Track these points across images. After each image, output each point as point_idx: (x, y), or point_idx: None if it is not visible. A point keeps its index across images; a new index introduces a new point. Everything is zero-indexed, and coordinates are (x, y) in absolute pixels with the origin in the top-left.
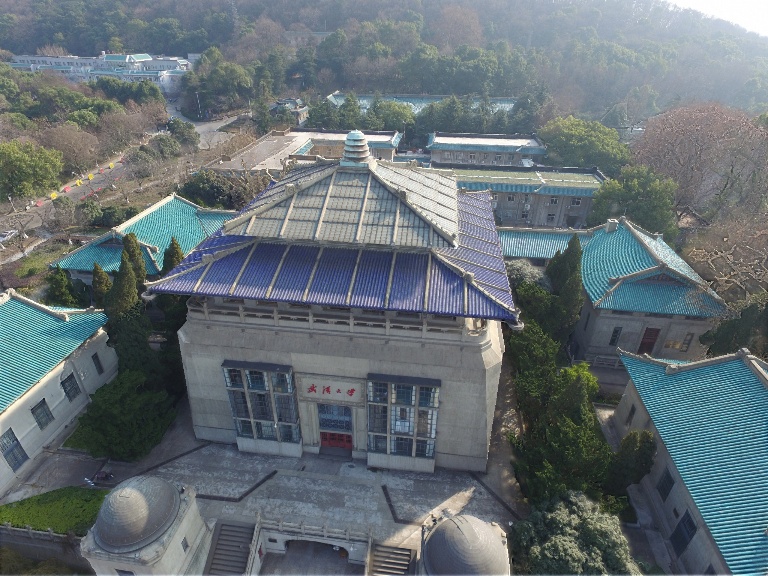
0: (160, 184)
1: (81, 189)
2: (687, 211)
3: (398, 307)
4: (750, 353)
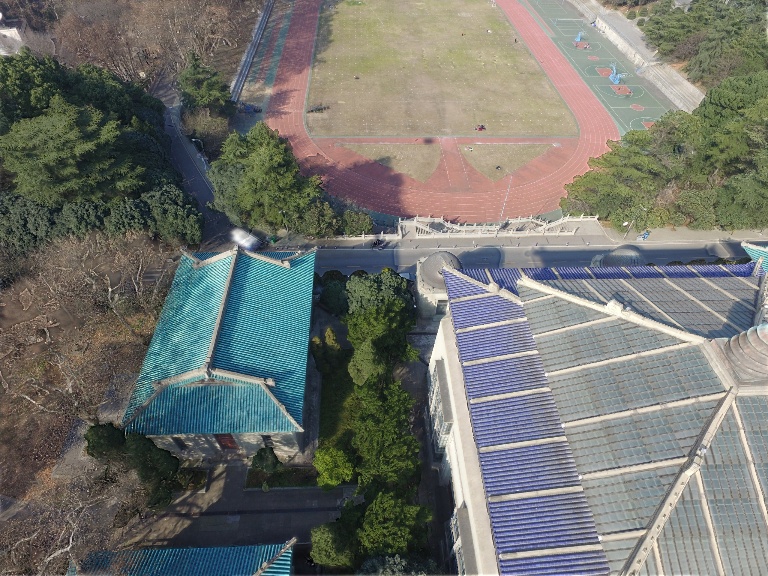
0: None
1: None
2: None
3: (542, 269)
4: None
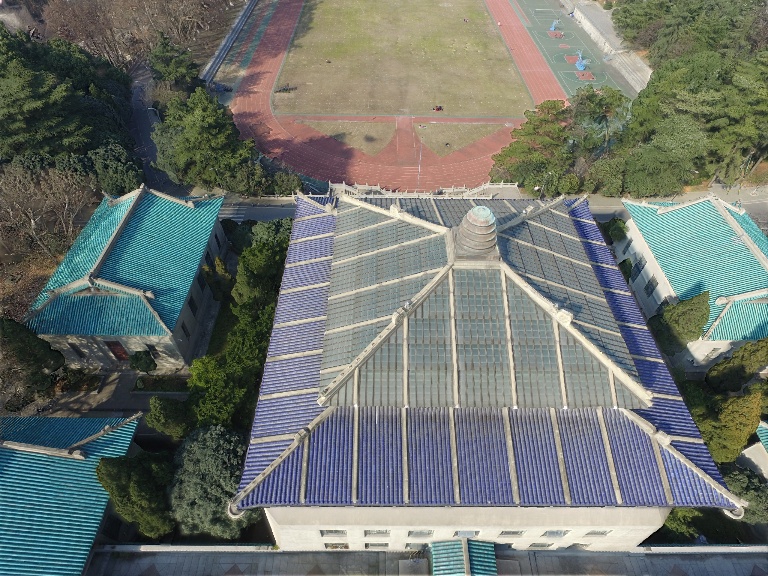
0: None
1: None
2: None
3: None
4: None
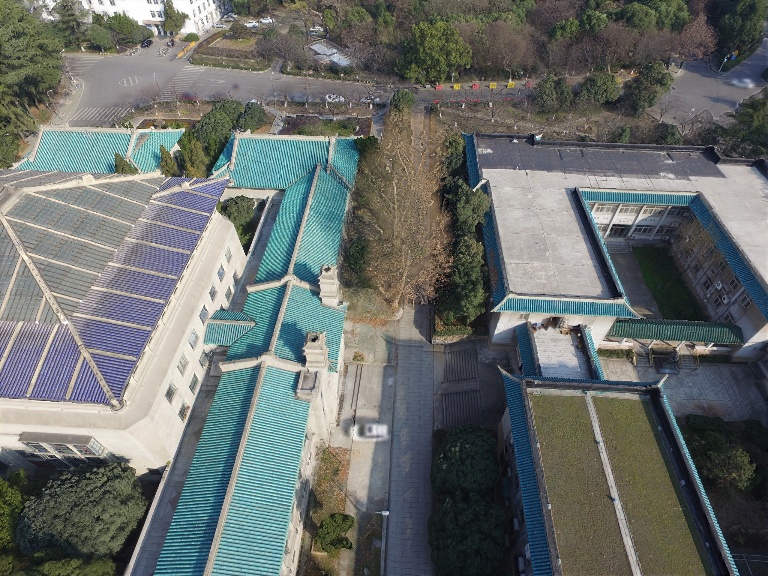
0: (513, 127)
1: (482, 92)
2: None
3: None
4: None
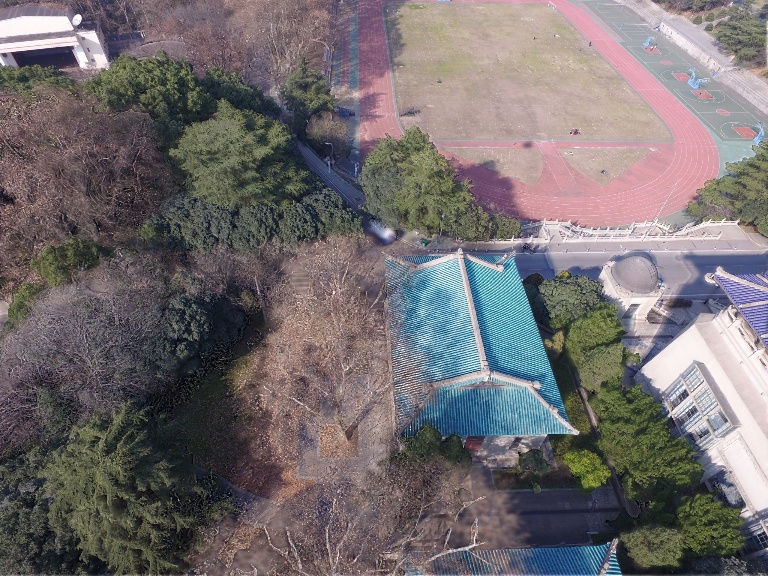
0: None
1: None
2: None
3: None
4: (483, 369)
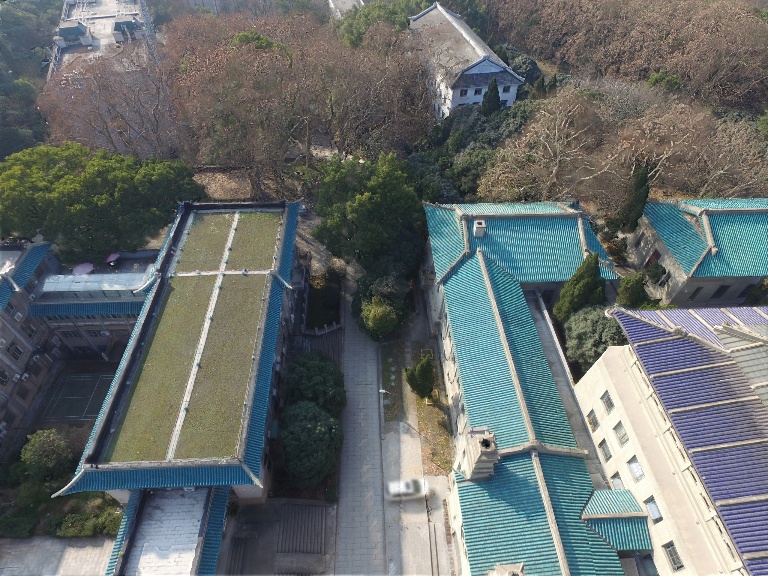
0: None
1: None
2: (196, 171)
3: None
4: None
